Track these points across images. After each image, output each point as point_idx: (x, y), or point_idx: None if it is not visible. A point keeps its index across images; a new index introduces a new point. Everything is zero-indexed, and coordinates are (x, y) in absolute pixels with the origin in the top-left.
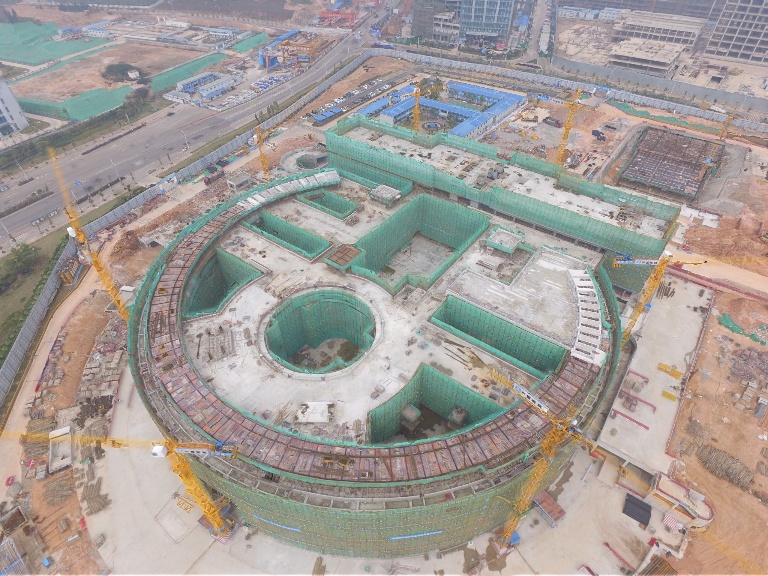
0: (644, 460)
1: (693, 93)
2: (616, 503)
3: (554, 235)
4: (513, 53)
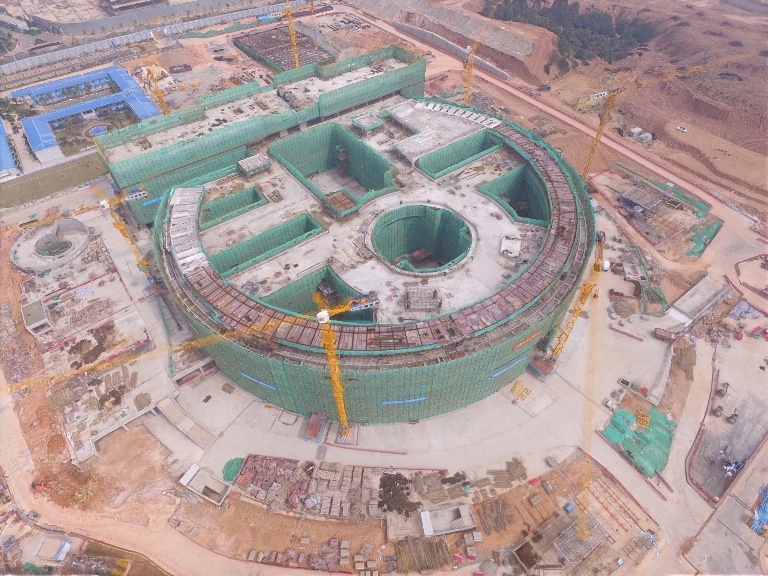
0: None
1: (207, 6)
2: None
3: (367, 105)
4: (4, 43)
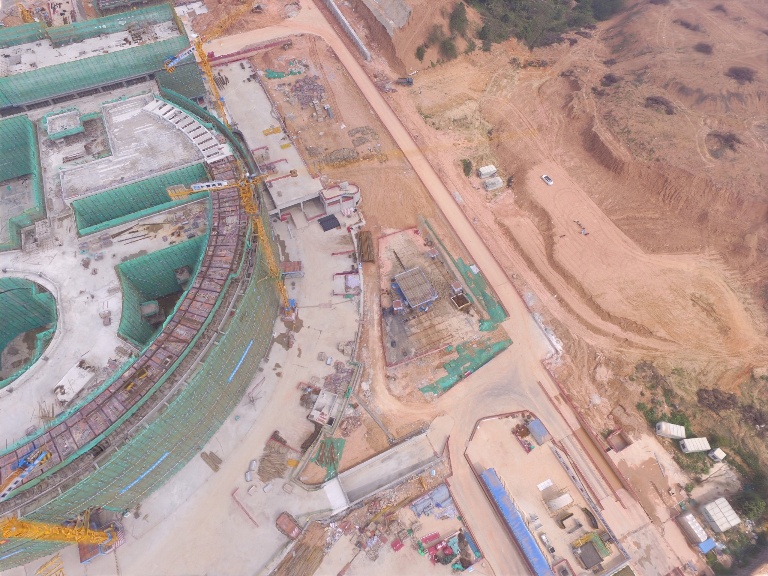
0: (307, 193)
1: None
2: (318, 231)
3: (101, 91)
4: None
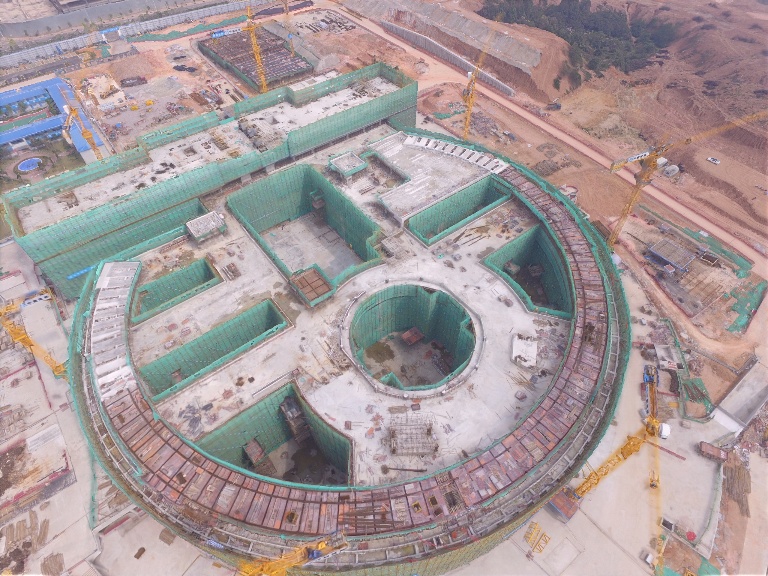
0: None
1: (171, 1)
2: None
3: (348, 138)
4: None
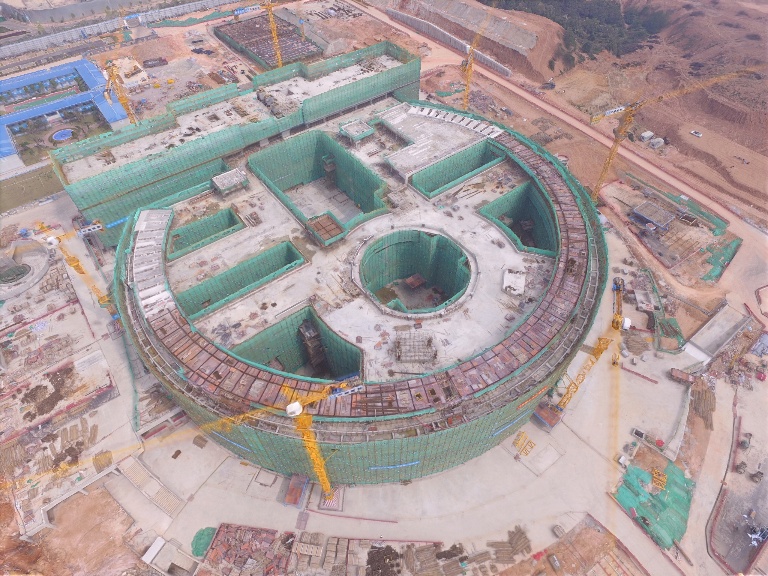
0: None
1: None
2: None
3: (356, 109)
4: None
